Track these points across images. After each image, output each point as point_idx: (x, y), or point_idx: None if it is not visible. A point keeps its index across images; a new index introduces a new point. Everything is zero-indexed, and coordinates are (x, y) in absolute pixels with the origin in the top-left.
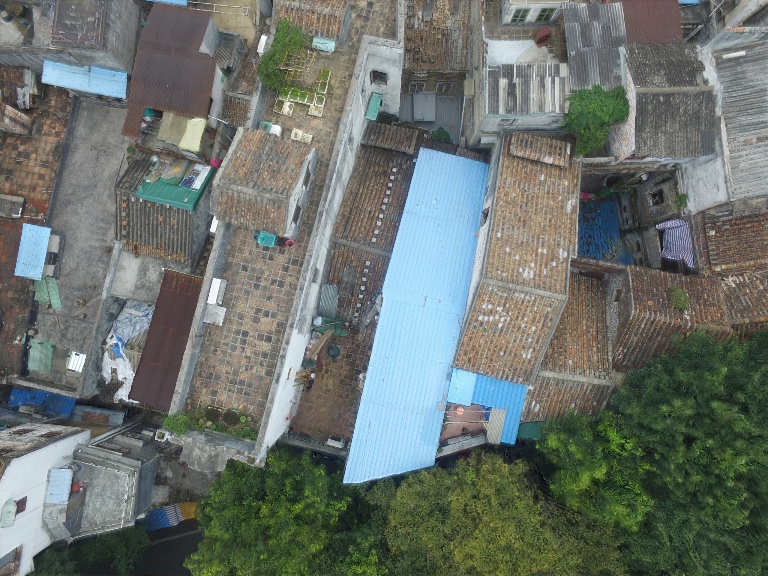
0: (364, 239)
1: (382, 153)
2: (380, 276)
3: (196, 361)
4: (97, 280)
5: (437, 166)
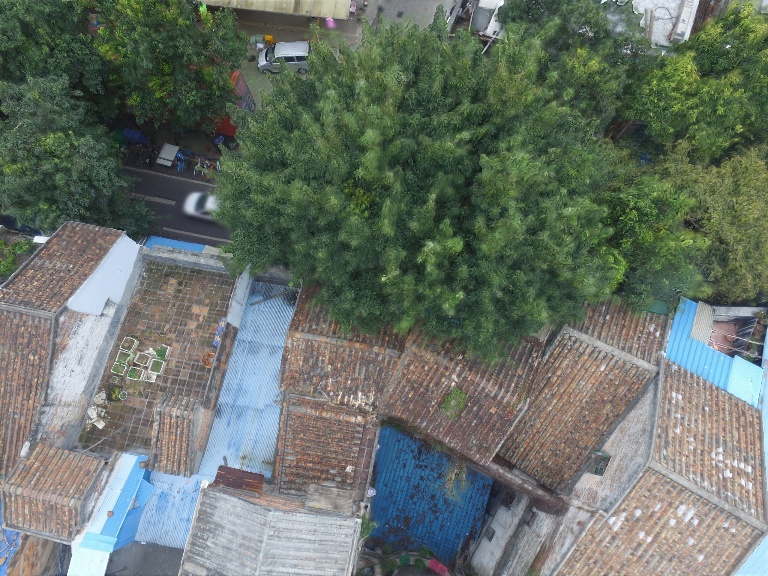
0: None
1: None
2: None
3: None
4: None
5: None
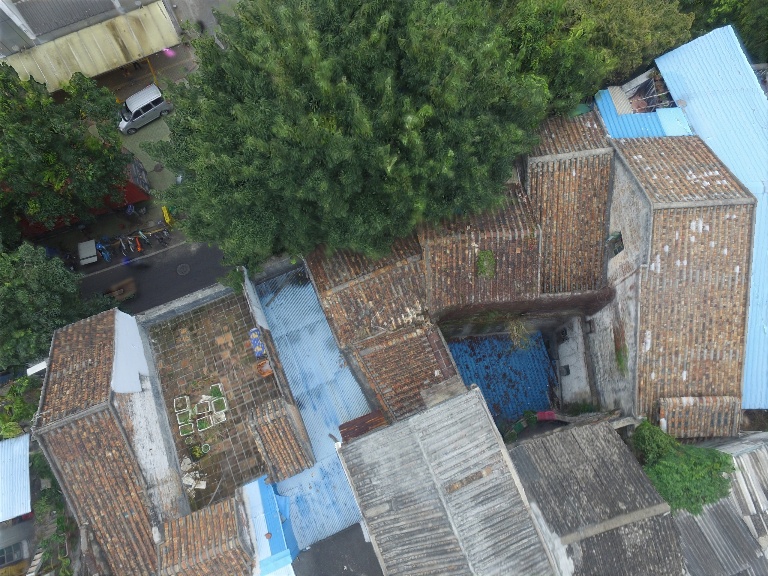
0: None
1: None
2: None
3: None
4: None
5: None
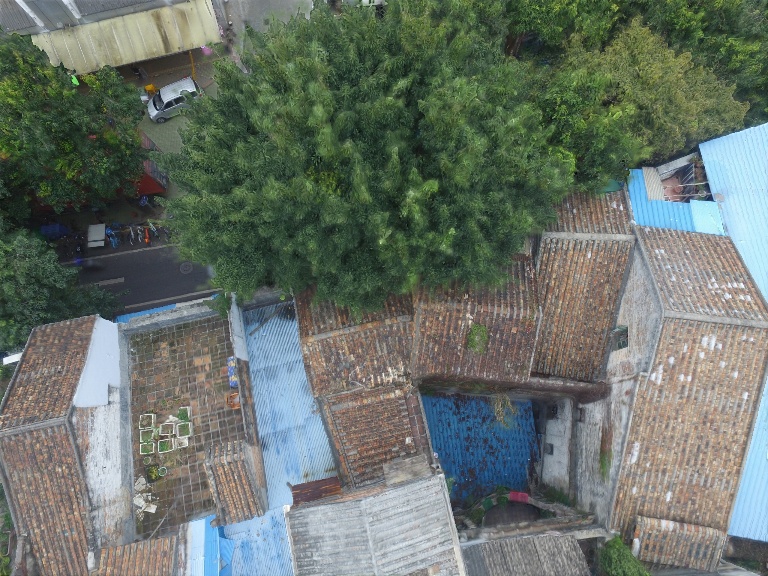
0: None
1: None
2: None
3: None
4: None
5: (763, 515)
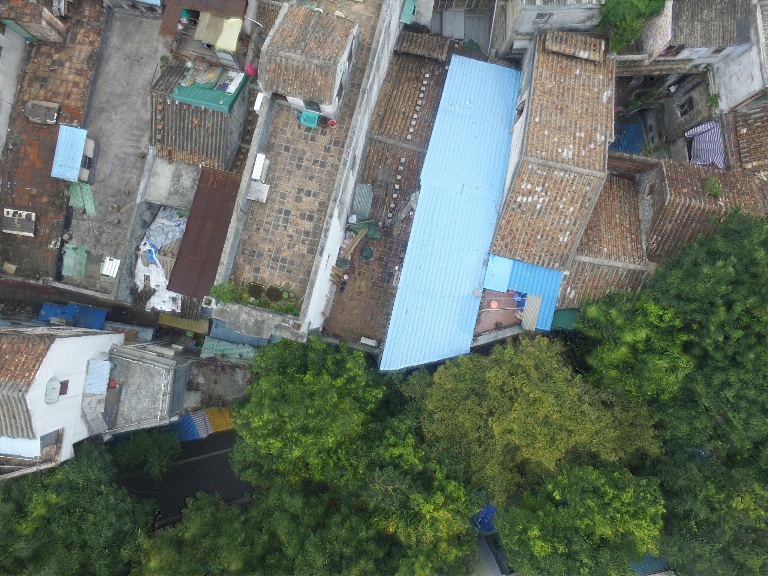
0: (399, 137)
1: (414, 61)
2: (414, 174)
3: (239, 239)
4: (131, 186)
5: (469, 71)
